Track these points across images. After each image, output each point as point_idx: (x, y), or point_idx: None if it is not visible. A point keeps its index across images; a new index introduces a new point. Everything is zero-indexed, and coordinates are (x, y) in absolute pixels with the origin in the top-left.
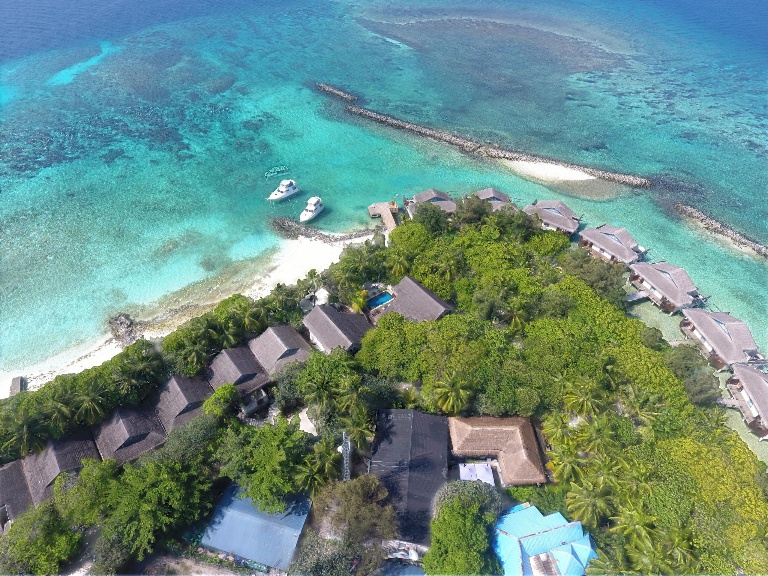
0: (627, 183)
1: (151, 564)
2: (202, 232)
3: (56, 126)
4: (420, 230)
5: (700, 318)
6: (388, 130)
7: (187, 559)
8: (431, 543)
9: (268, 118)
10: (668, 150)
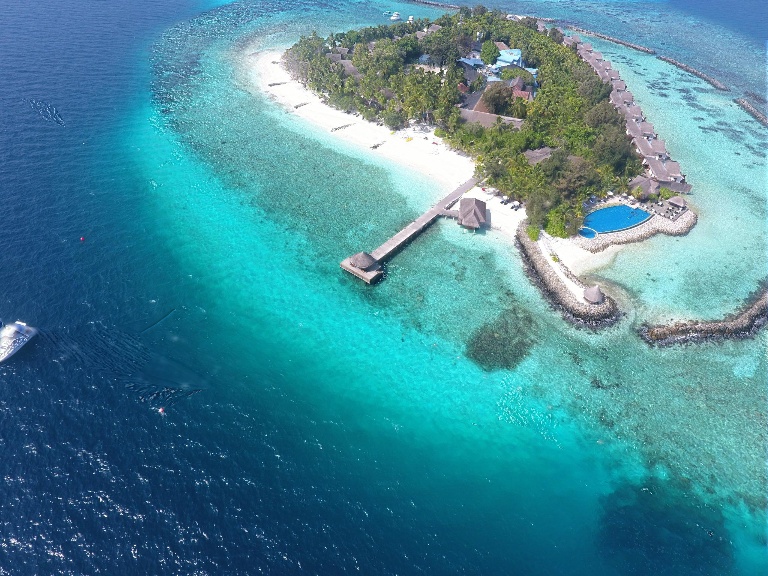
0: (545, 20)
1: (406, 64)
2: (368, 26)
3: (268, 1)
4: None
5: None
6: (430, 6)
7: (415, 64)
8: (482, 49)
9: None
10: (567, 14)
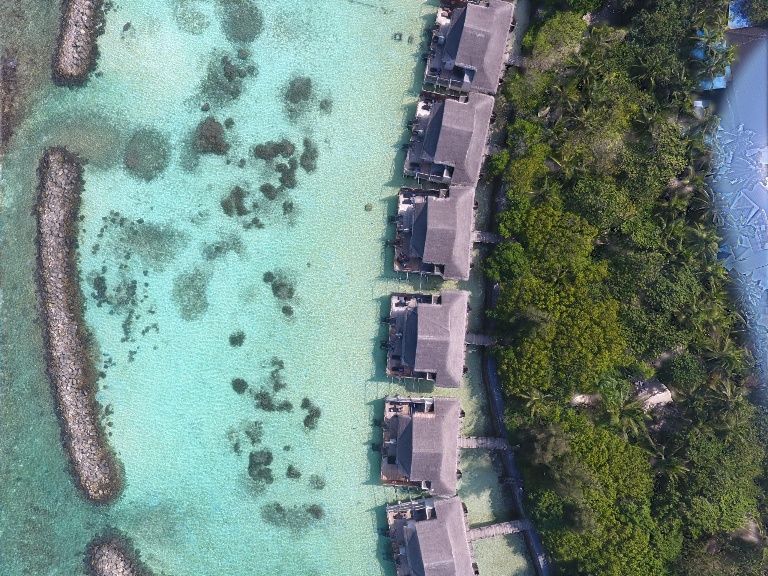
0: None
1: None
2: None
3: None
4: None
5: (466, 575)
6: None
7: None
8: None
9: None
10: None
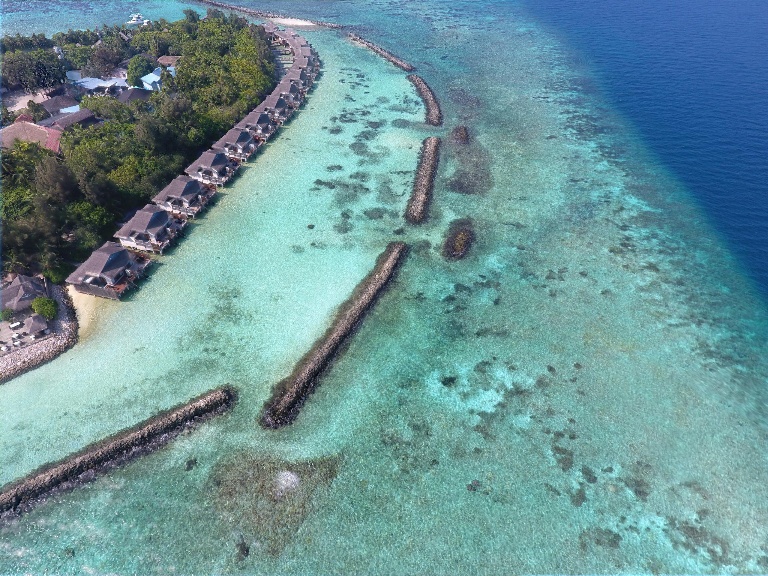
0: (330, 26)
1: None
2: None
3: None
4: (184, 20)
5: None
6: (213, 7)
7: None
8: None
9: (145, 1)
10: (374, 19)
